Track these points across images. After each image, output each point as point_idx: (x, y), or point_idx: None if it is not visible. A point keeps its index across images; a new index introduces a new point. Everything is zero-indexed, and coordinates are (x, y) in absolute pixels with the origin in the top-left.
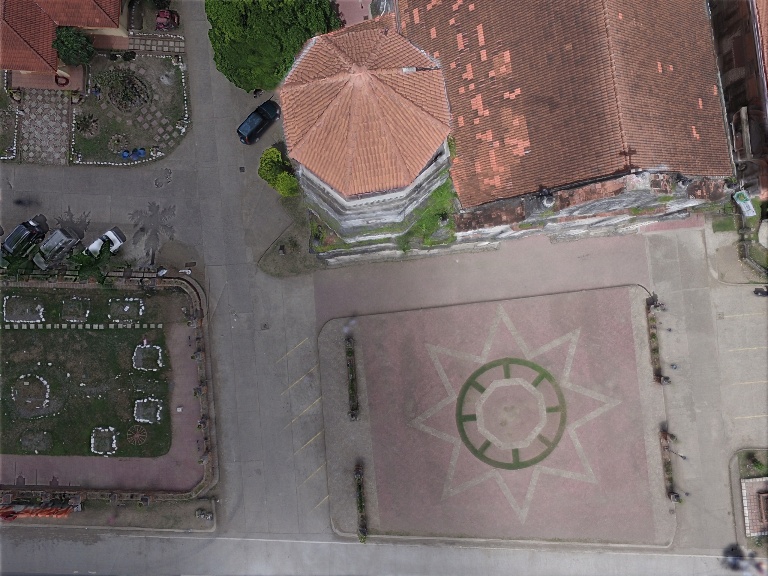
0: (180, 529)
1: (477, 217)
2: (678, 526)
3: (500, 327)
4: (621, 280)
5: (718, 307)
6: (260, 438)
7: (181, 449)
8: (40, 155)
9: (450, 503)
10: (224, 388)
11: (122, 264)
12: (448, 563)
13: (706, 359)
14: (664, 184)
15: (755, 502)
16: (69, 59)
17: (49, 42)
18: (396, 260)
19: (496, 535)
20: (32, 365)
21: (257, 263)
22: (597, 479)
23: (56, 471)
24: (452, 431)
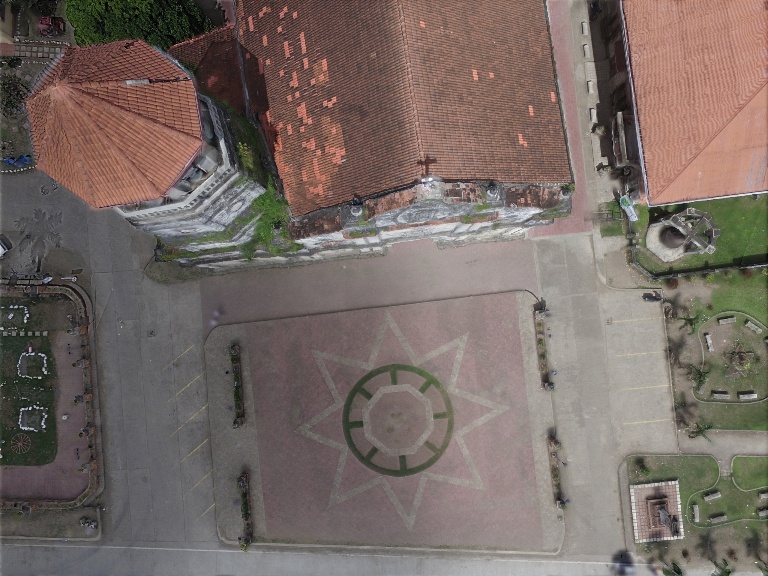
0: (65, 538)
1: (304, 226)
2: (567, 533)
3: (387, 333)
4: (509, 286)
5: (606, 312)
6: (146, 446)
7: (67, 457)
8: None
9: (337, 510)
10: (110, 396)
11: (8, 271)
12: (335, 571)
13: (595, 365)
14: (467, 193)
15: (643, 508)
16: None
17: None
18: (283, 266)
19: (383, 542)
20: None
21: (143, 270)
22: (485, 486)
23: None
24: (339, 438)
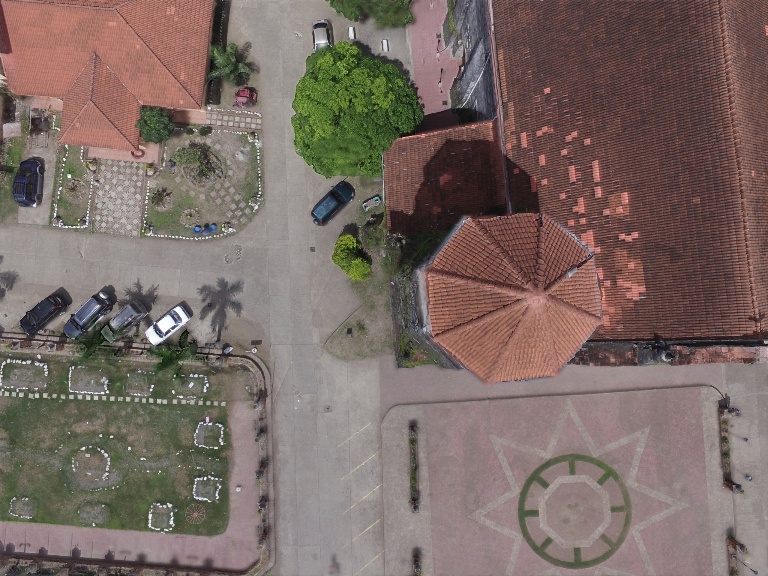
0: None
1: (582, 354)
2: None
3: (567, 422)
4: (693, 380)
5: None
6: (318, 522)
7: (238, 529)
8: (112, 226)
9: None
10: (284, 469)
11: (188, 339)
12: None
13: None
14: None
15: None
16: (150, 137)
17: (132, 122)
18: None
19: None
20: (94, 437)
21: (323, 345)
22: None
23: (112, 545)
24: (514, 526)
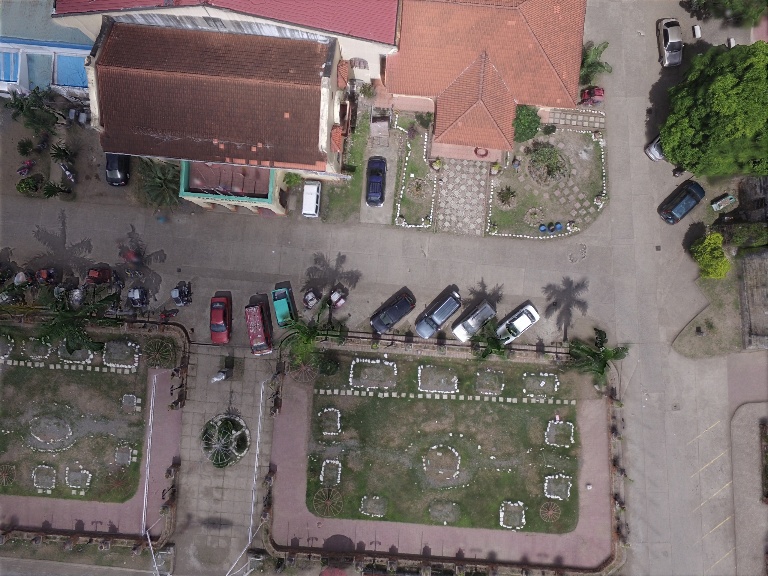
0: None
1: None
2: None
3: None
4: None
5: None
6: (668, 520)
7: (588, 527)
8: (455, 225)
9: None
10: (633, 467)
11: (534, 338)
12: None
13: None
14: None
15: None
16: (520, 137)
17: (510, 121)
18: None
19: None
20: (443, 435)
21: (671, 343)
22: None
23: (462, 543)
24: None
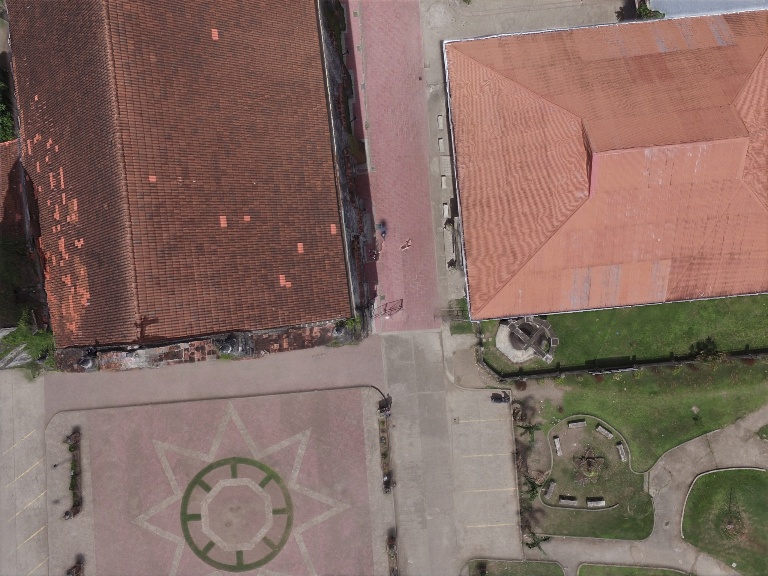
0: None
1: (62, 360)
2: None
3: (229, 425)
4: (355, 381)
5: (454, 411)
6: None
7: None
8: None
9: None
10: None
11: None
12: None
13: (440, 465)
14: (191, 353)
15: None
16: None
17: None
18: None
19: None
20: None
21: None
22: None
23: None
24: (176, 530)
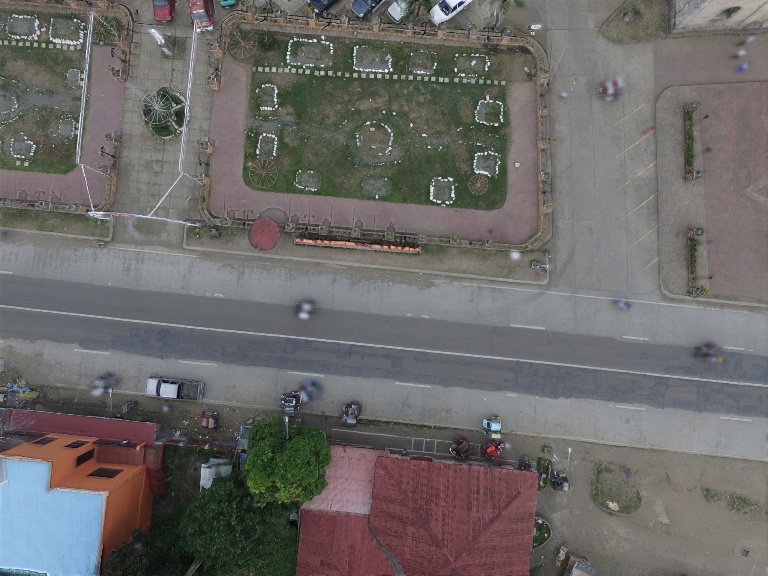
0: (514, 279)
1: None
2: None
3: None
4: None
5: None
6: (593, 198)
7: (515, 204)
8: None
9: None
10: (561, 148)
11: (467, 23)
12: None
13: None
14: None
15: None
16: None
17: None
18: (737, 33)
19: None
20: (377, 113)
21: (599, 29)
22: None
23: (393, 217)
24: None
